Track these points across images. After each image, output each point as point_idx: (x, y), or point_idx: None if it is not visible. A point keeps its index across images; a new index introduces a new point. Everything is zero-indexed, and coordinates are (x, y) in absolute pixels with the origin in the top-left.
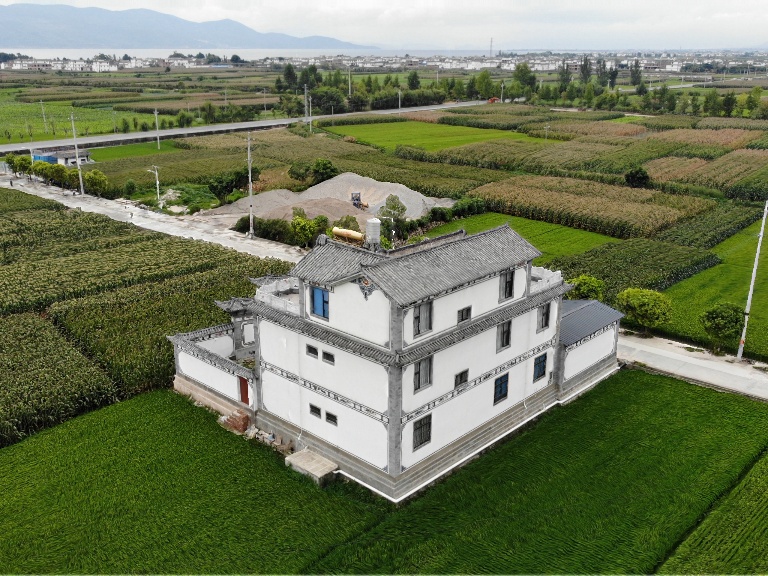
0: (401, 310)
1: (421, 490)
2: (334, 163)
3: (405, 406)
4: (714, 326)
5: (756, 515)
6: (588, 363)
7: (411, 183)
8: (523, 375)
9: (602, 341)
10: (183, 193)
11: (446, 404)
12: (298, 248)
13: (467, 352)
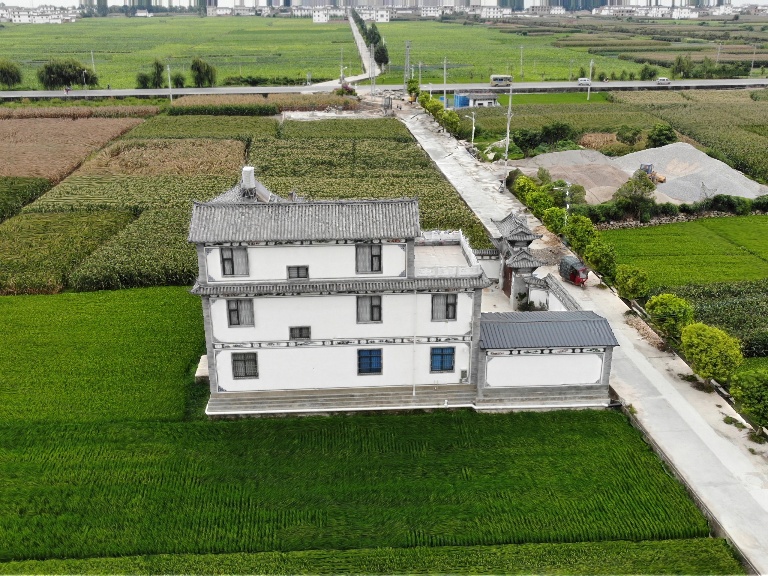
0: (202, 247)
1: (242, 416)
2: (718, 132)
3: (218, 334)
4: (735, 396)
5: (419, 573)
6: (540, 381)
7: (765, 165)
8: (410, 359)
9: (571, 364)
10: (513, 142)
11: (279, 350)
12: (522, 208)
13: (307, 310)
